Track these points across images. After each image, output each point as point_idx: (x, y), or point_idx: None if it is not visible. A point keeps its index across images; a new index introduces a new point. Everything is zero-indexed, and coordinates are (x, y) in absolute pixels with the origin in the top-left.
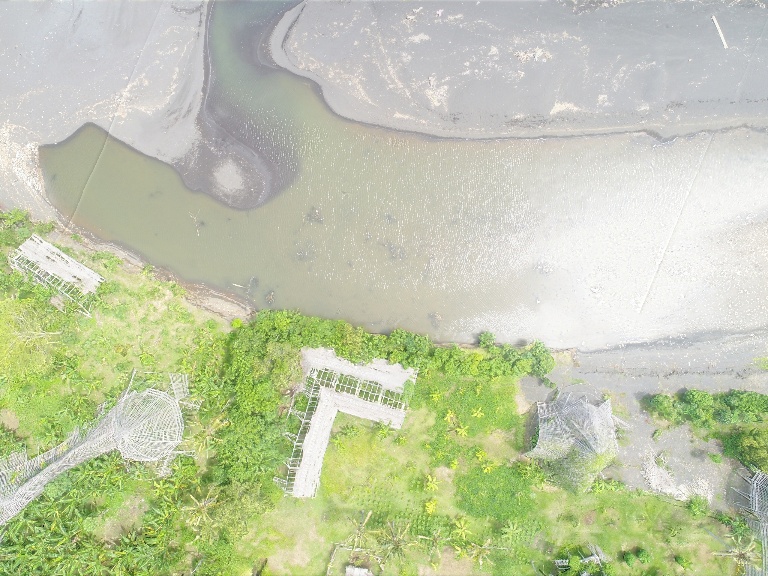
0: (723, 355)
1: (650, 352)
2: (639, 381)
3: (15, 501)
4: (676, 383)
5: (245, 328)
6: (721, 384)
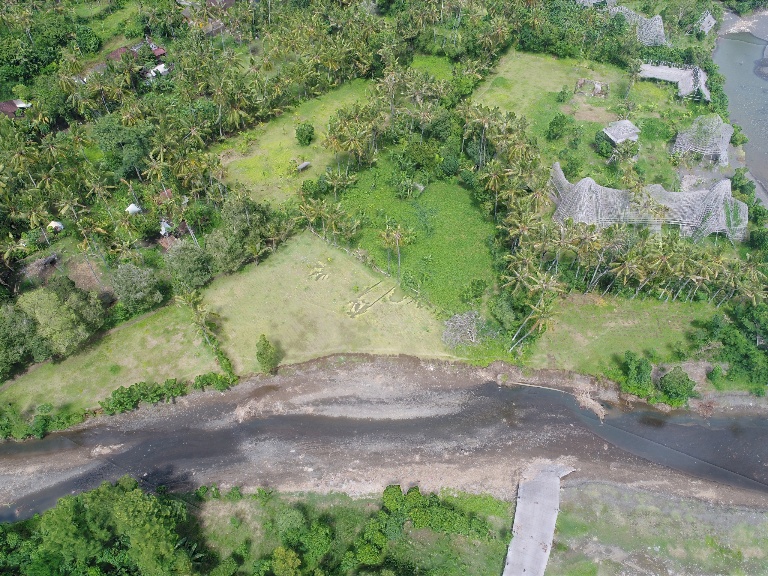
0: None
1: (762, 191)
2: None
3: None
4: None
5: None
6: None
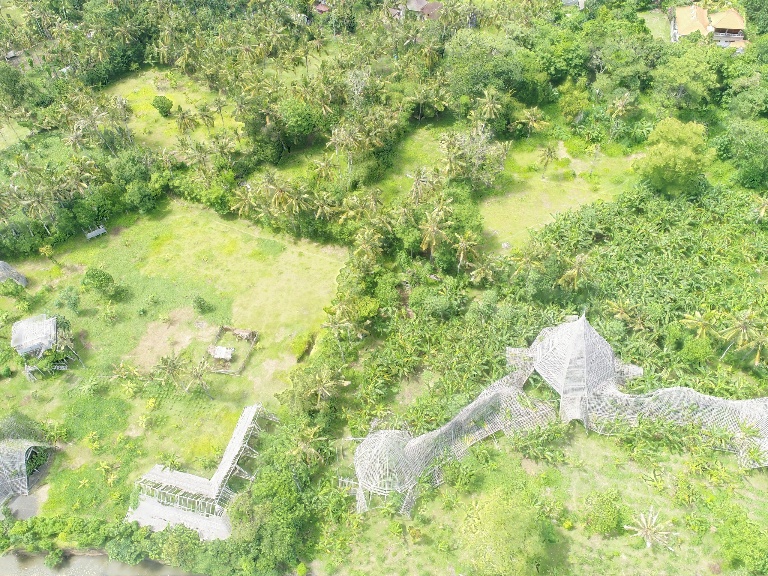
0: None
1: None
2: None
3: (494, 391)
4: None
5: (288, 561)
6: None
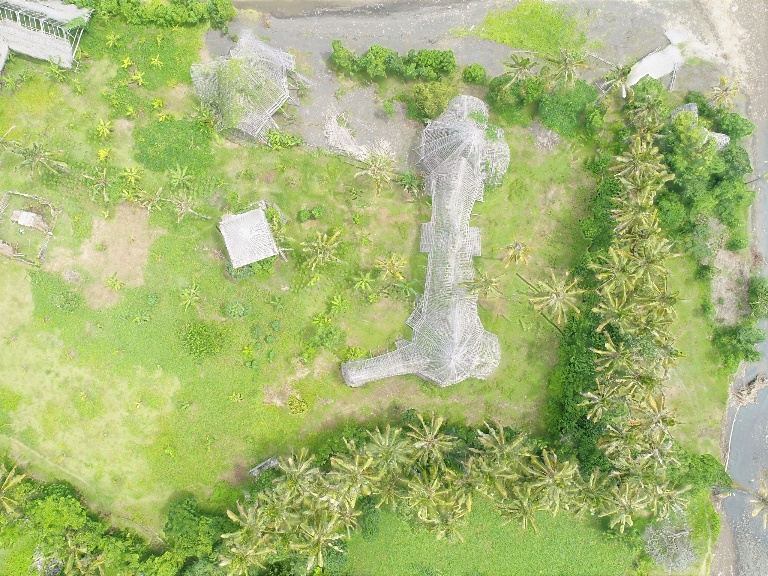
0: (419, 25)
1: (345, 20)
2: (326, 41)
3: None
4: (364, 44)
5: None
6: (409, 47)
